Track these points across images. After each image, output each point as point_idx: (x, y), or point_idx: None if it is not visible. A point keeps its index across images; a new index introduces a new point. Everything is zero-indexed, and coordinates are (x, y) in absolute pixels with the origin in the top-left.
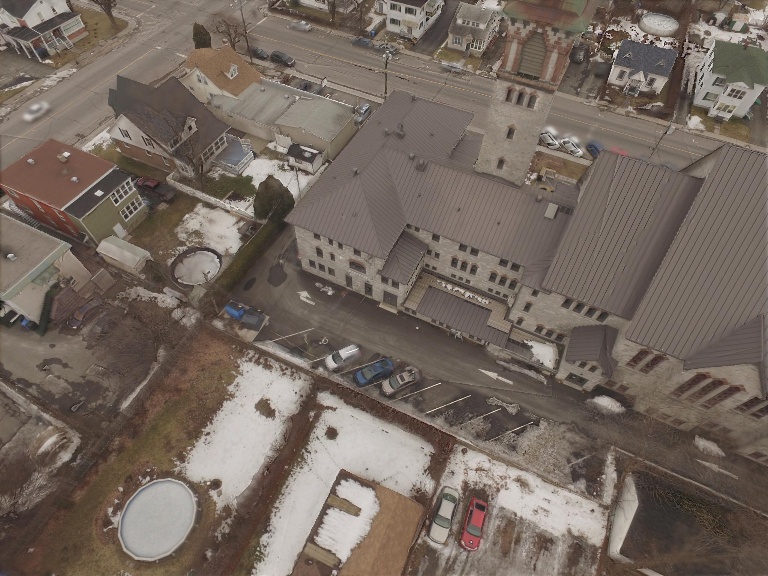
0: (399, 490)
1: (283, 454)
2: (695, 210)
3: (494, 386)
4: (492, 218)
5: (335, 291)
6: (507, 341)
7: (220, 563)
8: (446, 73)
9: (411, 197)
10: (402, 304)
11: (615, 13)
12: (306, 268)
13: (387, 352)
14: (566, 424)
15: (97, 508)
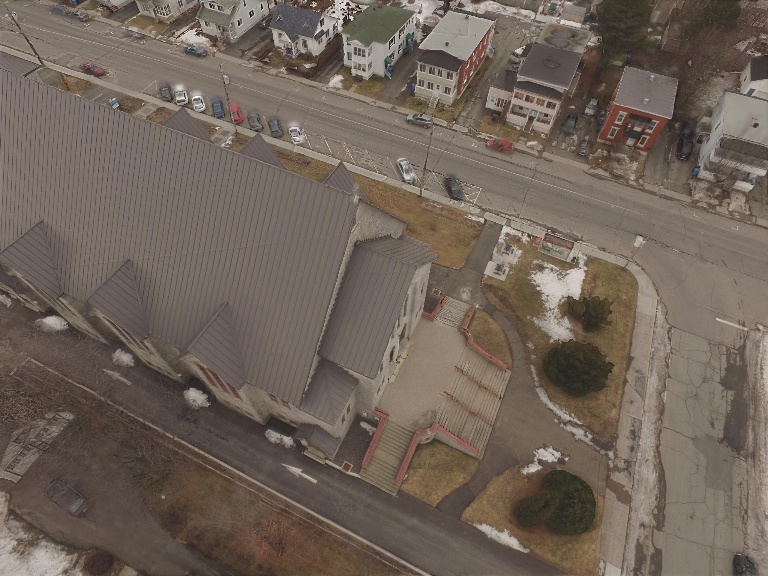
0: None
1: None
2: None
3: None
4: None
5: None
6: None
7: None
8: (126, 38)
9: None
10: None
11: None
12: None
13: None
14: (1, 340)
15: None
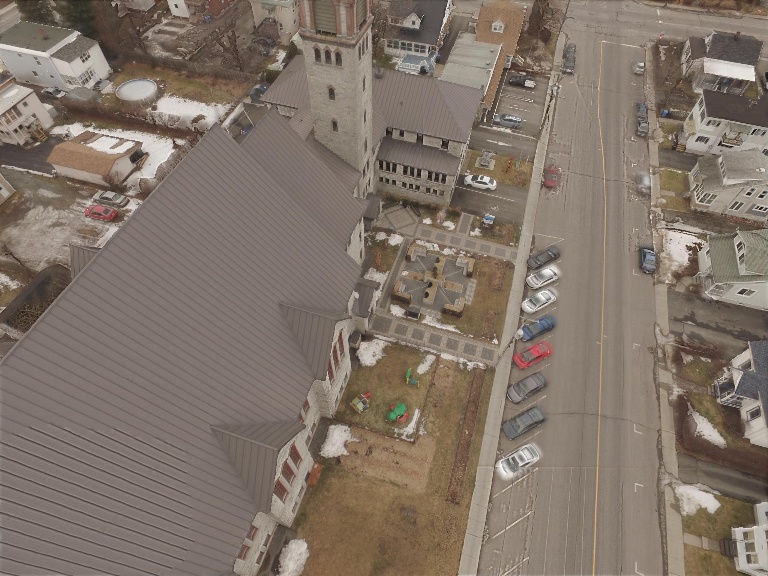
0: (133, 179)
1: (166, 128)
2: None
3: None
4: None
5: None
6: None
7: (102, 106)
8: (632, 180)
9: None
10: None
11: None
12: None
13: None
14: None
15: (150, 75)
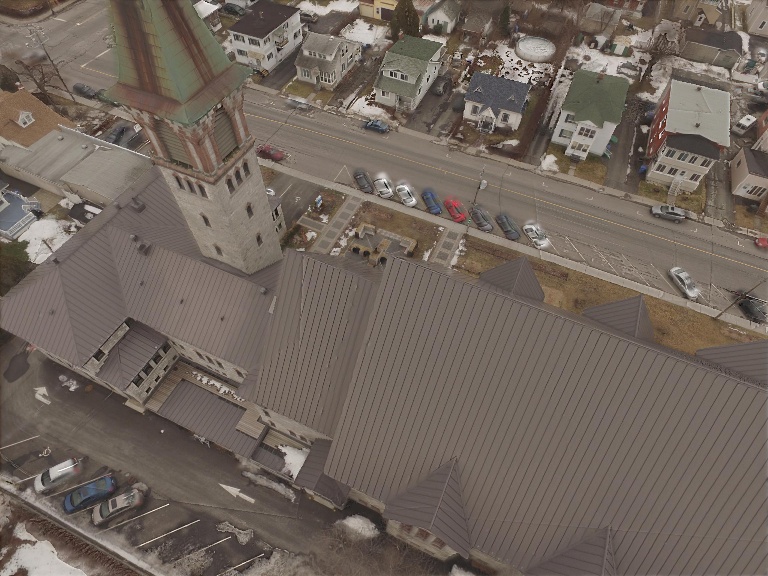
0: None
1: None
2: (370, 331)
3: (231, 506)
4: (216, 312)
5: (79, 385)
6: (259, 447)
7: None
8: (290, 110)
9: (133, 286)
10: (143, 404)
11: (493, 36)
12: (50, 358)
13: (117, 464)
14: (303, 555)
15: None
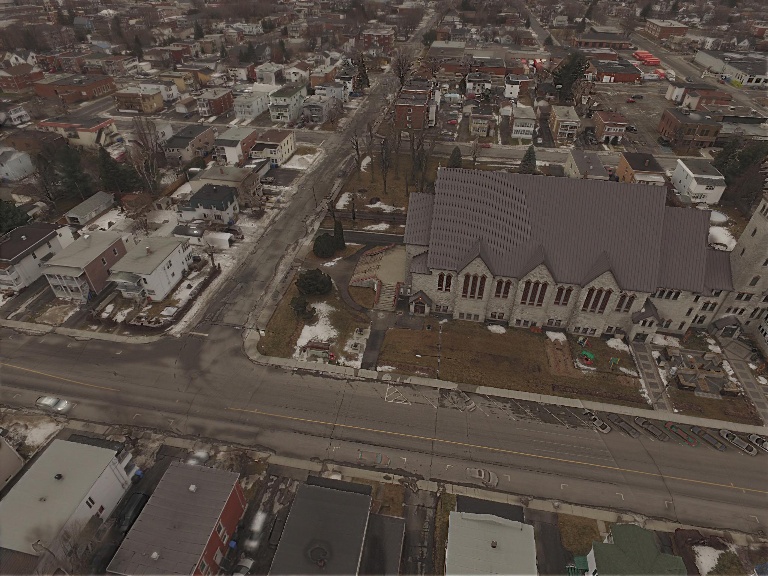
0: None
1: None
2: None
3: None
4: None
5: None
6: None
7: None
8: None
9: None
10: None
11: None
12: None
13: None
14: None
15: None
